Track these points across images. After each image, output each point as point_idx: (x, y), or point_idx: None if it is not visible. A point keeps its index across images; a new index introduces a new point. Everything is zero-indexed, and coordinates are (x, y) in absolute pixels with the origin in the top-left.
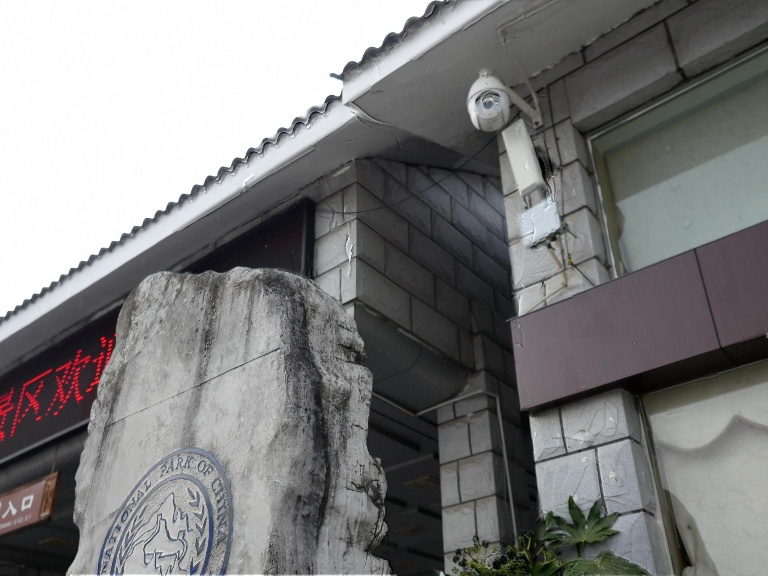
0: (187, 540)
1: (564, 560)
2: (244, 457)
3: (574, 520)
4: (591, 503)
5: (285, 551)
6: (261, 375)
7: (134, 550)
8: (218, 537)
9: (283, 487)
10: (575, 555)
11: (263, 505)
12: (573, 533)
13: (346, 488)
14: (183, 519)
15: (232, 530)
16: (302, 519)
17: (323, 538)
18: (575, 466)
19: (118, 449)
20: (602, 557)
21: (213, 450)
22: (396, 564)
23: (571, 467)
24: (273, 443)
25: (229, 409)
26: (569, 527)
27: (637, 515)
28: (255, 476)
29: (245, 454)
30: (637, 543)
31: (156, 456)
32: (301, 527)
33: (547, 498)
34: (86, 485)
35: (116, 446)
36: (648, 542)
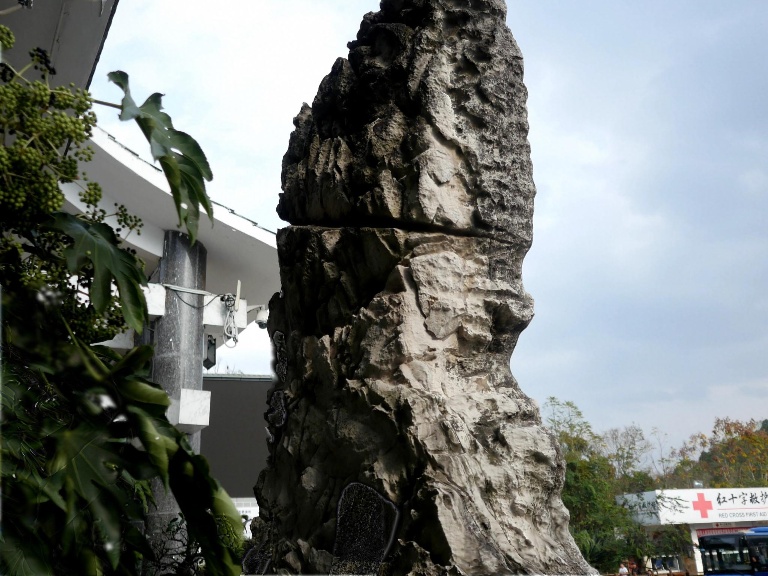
0: None
1: None
2: None
3: None
4: None
5: None
6: None
7: None
8: None
9: None
10: None
11: None
12: None
13: None
14: None
15: None
16: None
17: None
18: None
19: None
20: None
21: None
22: (270, 396)
23: None
24: None
25: None
26: None
27: None
28: None
29: None
30: None
31: None
32: None
33: None
34: None
35: None
36: None
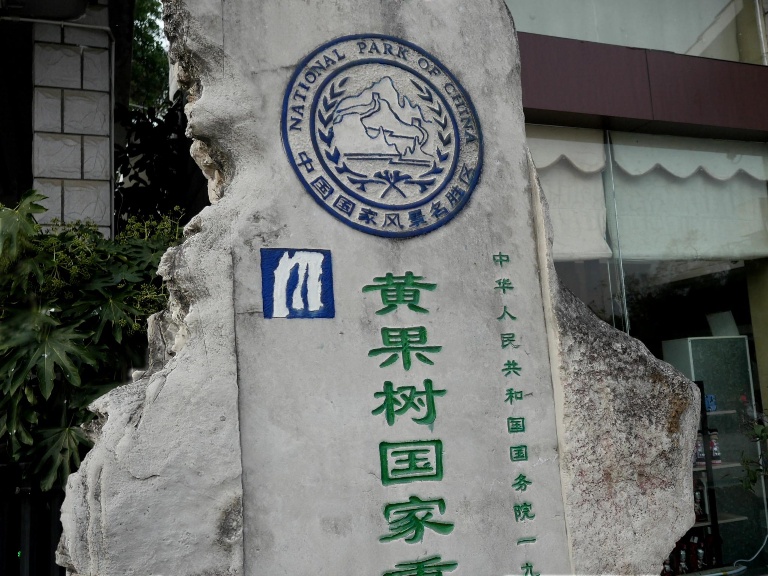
0: (427, 129)
1: None
2: (480, 75)
3: None
4: None
5: None
6: (481, 5)
7: (345, 118)
8: (466, 137)
9: None
10: None
11: (514, 124)
12: None
13: None
14: (415, 108)
15: (482, 135)
16: None
17: None
18: None
19: None
20: None
21: (436, 54)
22: None
23: None
24: (510, 75)
25: (447, 21)
26: None
27: None
28: (498, 97)
29: (480, 73)
30: None
31: (344, 27)
32: None
33: None
34: (211, 14)
35: None
36: None
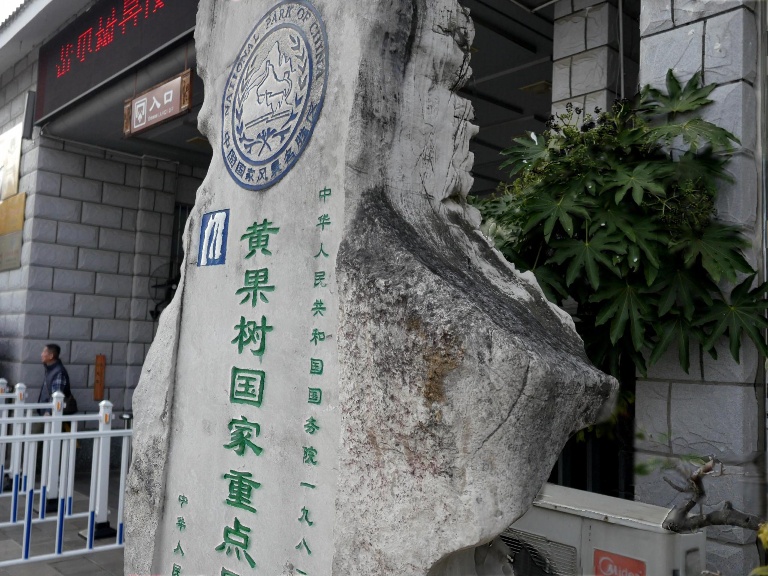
0: (291, 79)
1: (652, 127)
2: None
3: (669, 92)
4: (690, 75)
5: (373, 79)
6: None
7: (249, 94)
8: (317, 73)
9: (371, 23)
10: (664, 123)
11: (354, 40)
12: (666, 104)
13: (433, 30)
14: (287, 62)
15: (328, 66)
16: (390, 54)
17: (409, 73)
18: (680, 39)
19: (228, 10)
20: (689, 121)
21: None
22: (478, 103)
23: (676, 40)
24: None
25: None
26: (663, 98)
27: (735, 85)
28: (347, 16)
29: None
30: (729, 111)
31: (261, 11)
32: (389, 61)
33: (646, 72)
34: (205, 45)
35: (226, 7)
36: (740, 109)
